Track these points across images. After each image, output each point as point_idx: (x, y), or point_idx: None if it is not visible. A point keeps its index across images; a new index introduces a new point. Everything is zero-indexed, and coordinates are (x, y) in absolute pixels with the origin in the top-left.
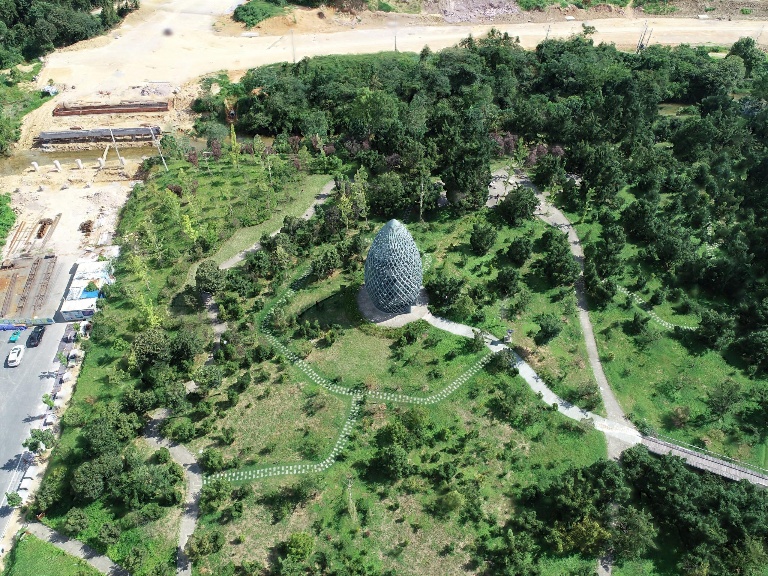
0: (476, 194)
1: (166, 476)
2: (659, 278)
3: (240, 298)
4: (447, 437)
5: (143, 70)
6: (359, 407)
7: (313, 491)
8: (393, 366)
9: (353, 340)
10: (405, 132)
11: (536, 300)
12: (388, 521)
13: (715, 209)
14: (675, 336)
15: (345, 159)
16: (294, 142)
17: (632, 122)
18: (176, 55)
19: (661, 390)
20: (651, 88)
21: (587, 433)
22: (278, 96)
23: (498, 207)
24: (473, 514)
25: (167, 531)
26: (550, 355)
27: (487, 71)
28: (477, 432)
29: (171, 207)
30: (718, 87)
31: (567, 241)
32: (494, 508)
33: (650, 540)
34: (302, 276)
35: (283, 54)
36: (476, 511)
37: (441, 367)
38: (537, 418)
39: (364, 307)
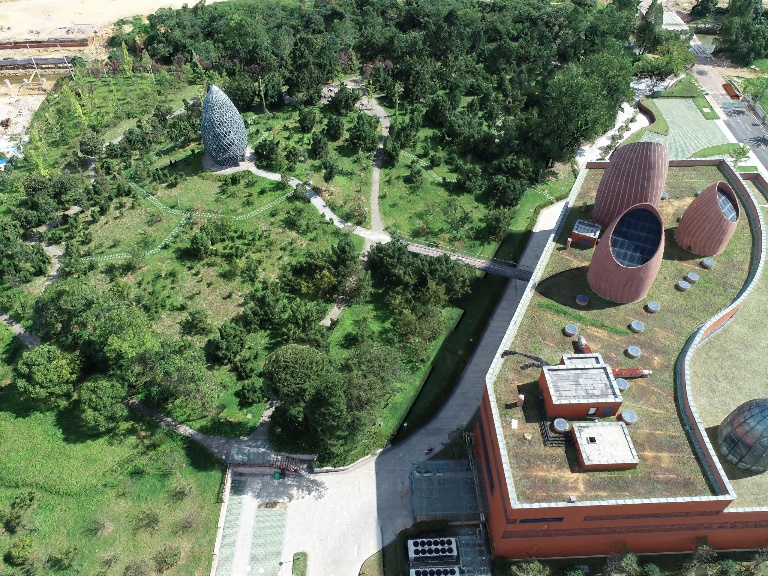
0: (310, 90)
1: (34, 252)
2: (446, 151)
3: (116, 162)
4: (245, 236)
5: (71, 15)
6: (187, 221)
7: (141, 265)
8: (218, 197)
9: (193, 183)
10: (272, 53)
11: (342, 161)
12: (191, 281)
13: (507, 107)
14: (442, 185)
15: (221, 74)
16: (180, 60)
17: (448, 41)
18: (101, 5)
19: (418, 215)
20: (496, 27)
21: (351, 237)
22: (177, 31)
23: (329, 101)
24: (249, 274)
25: (34, 289)
26: (339, 192)
27: (356, 12)
28: (269, 234)
29: (66, 98)
30: (552, 27)
31: (376, 123)
32: (269, 275)
33: (365, 285)
34: (166, 148)
35: (194, 4)
36: (253, 274)
37: (254, 198)
38: (316, 227)
39: (206, 163)
